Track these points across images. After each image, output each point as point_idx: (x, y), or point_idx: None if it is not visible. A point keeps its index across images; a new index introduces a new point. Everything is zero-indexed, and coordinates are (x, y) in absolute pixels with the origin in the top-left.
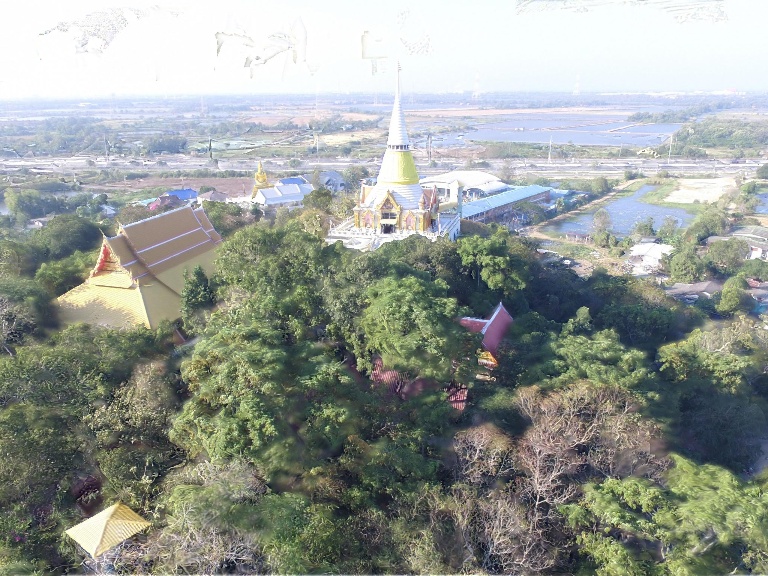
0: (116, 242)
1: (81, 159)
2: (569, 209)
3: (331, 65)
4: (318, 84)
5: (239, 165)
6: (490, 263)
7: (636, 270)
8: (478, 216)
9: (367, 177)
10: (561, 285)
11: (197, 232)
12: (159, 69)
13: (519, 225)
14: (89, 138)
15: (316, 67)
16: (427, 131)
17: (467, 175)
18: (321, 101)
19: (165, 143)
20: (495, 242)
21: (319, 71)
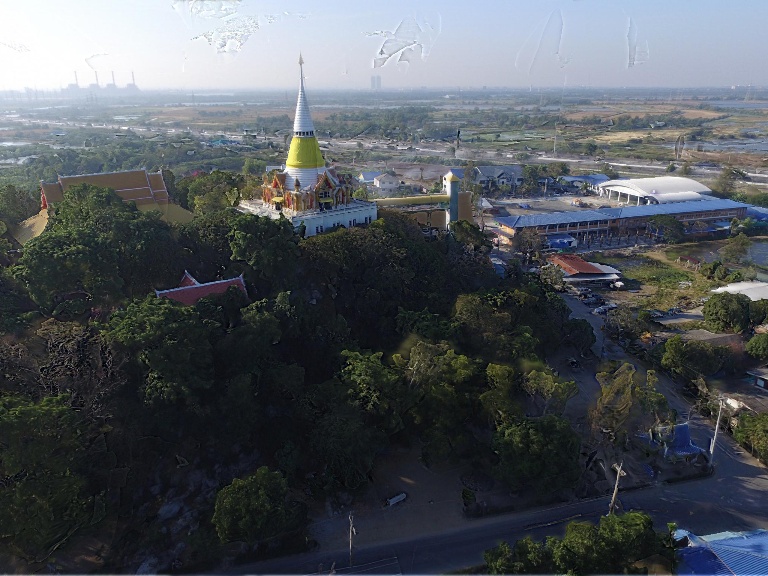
0: (52, 187)
1: (356, 141)
2: (758, 233)
3: (584, 57)
4: (566, 77)
5: (472, 155)
6: (236, 237)
7: (699, 309)
8: (597, 224)
9: (565, 175)
10: (393, 282)
11: (142, 190)
12: (349, 64)
13: (651, 241)
14: (385, 124)
15: (568, 59)
16: (751, 133)
17: (664, 181)
18: (568, 94)
19: (440, 132)
20: (244, 219)
21: (570, 63)
